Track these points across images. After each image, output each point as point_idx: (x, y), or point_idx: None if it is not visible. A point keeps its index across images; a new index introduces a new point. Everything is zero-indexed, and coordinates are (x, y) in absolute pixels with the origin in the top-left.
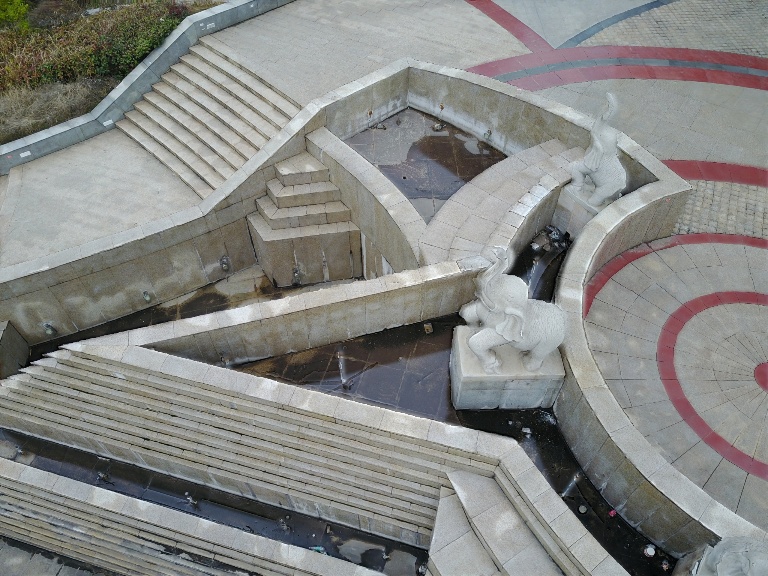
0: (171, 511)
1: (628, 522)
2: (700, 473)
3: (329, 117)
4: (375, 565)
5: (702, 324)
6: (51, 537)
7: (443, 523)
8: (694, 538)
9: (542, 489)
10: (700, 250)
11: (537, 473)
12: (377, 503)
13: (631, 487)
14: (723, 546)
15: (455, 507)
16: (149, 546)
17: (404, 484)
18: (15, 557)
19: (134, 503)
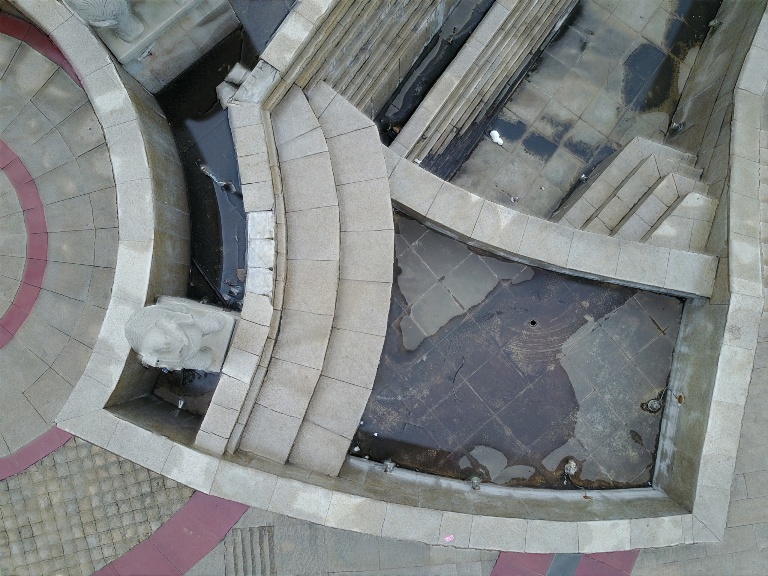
0: None
1: None
2: None
3: (716, 311)
4: None
5: (8, 271)
6: None
7: None
8: None
9: None
10: (58, 403)
11: None
12: None
13: None
14: None
15: None
16: None
17: None
18: None
19: None
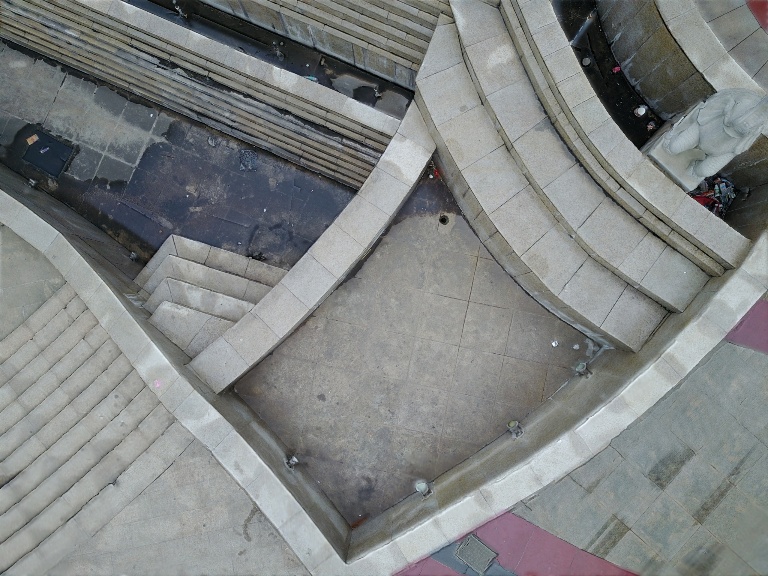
0: (160, 19)
1: (629, 80)
2: (727, 40)
3: None
4: (366, 101)
5: None
6: (47, 40)
7: (435, 51)
8: (690, 95)
9: (547, 21)
10: None
11: (546, 3)
12: (372, 31)
13: (645, 35)
14: (716, 96)
15: (451, 37)
16: (144, 58)
17: (401, 8)
18: (18, 60)
19: (120, 5)
